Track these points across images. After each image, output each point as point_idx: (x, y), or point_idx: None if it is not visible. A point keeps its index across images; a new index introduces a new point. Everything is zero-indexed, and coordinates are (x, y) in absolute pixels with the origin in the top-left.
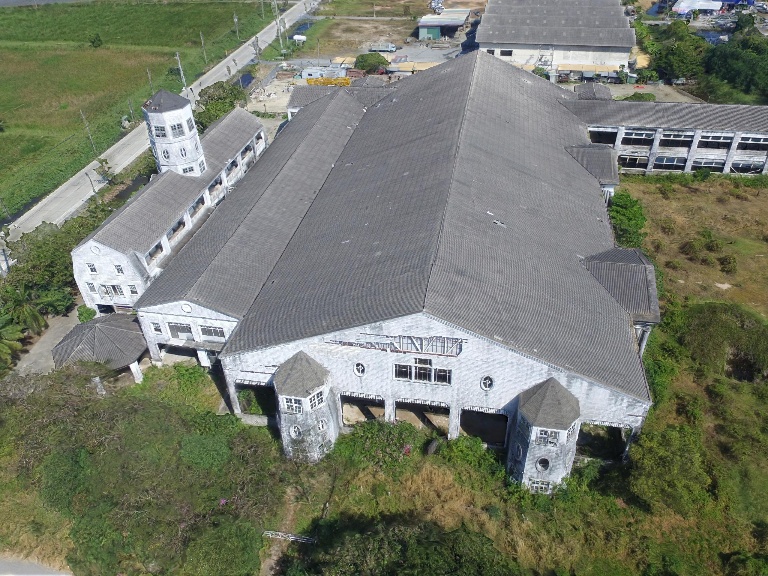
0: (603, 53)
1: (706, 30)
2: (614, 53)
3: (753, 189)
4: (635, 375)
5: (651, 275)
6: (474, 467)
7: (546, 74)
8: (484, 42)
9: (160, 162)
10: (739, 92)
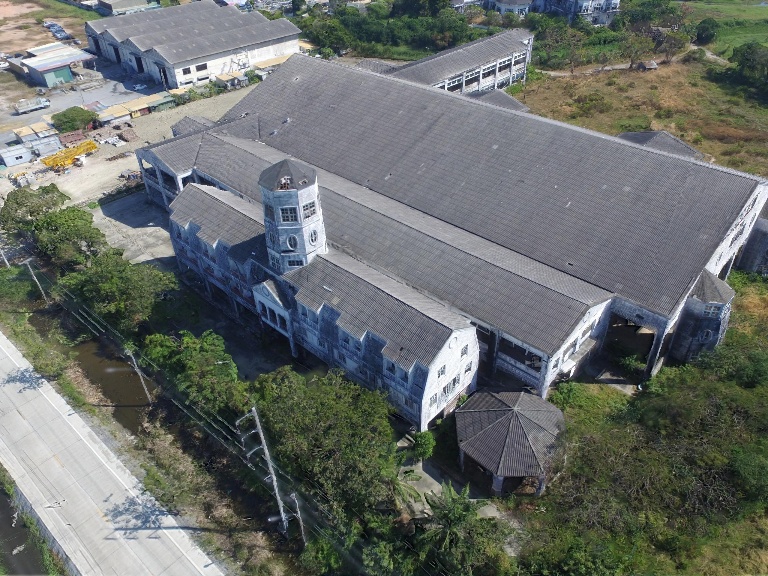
0: (280, 44)
1: (272, 15)
2: (287, 42)
3: (516, 96)
4: (761, 177)
5: (671, 135)
6: (746, 286)
7: (257, 75)
8: (178, 62)
9: (306, 251)
10: (392, 47)
